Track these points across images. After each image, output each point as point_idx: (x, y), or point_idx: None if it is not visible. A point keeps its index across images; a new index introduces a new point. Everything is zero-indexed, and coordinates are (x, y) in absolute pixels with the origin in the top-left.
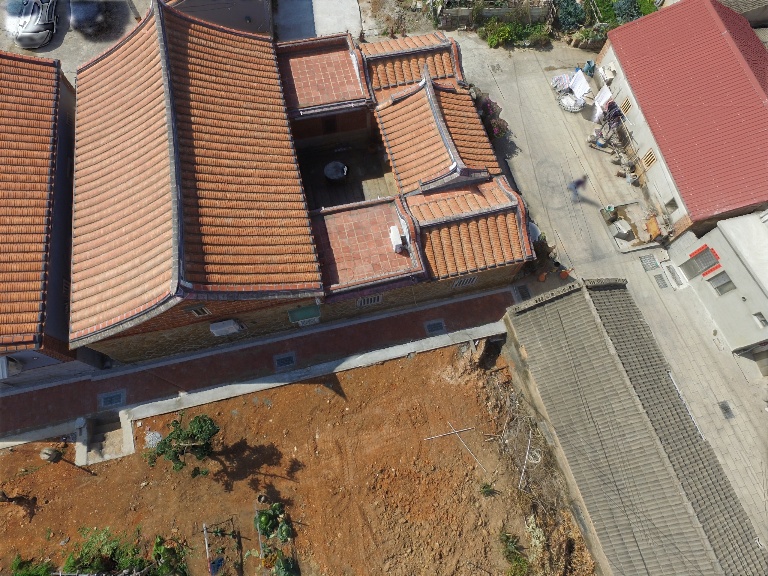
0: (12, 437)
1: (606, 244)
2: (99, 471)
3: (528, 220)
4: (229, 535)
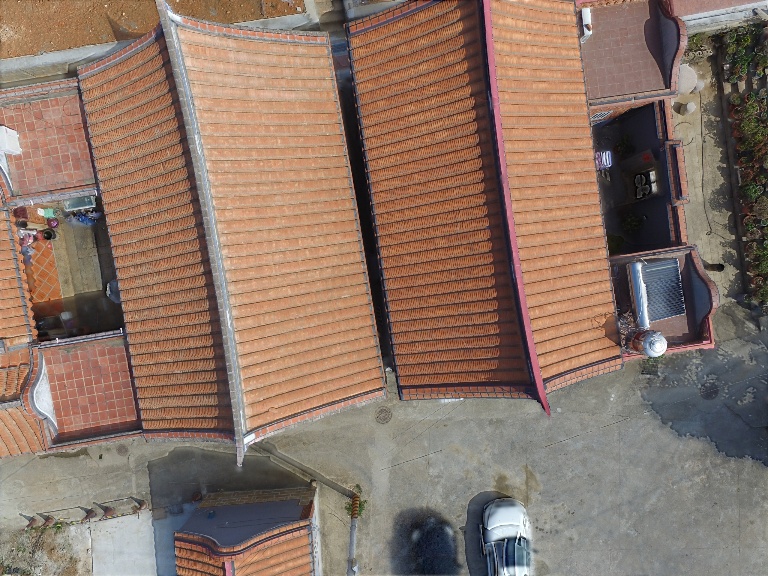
0: None
1: None
2: None
3: None
4: None
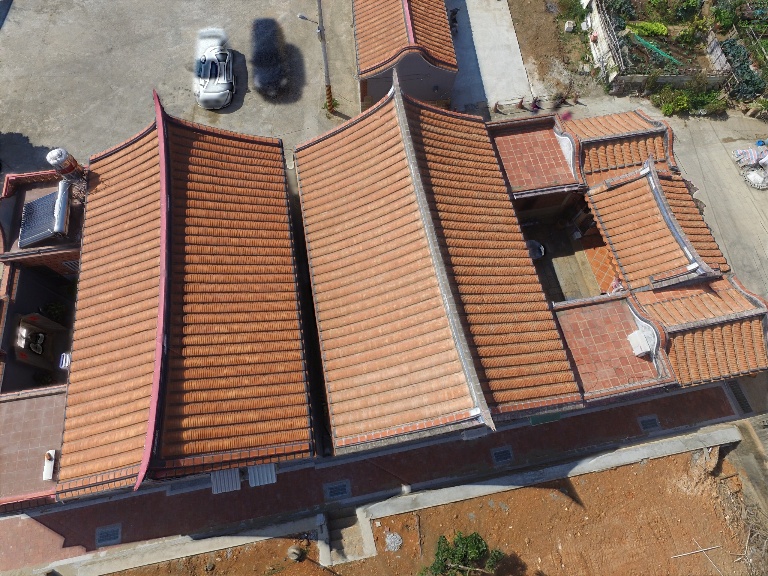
0: (255, 531)
1: None
2: (344, 573)
3: None
4: None
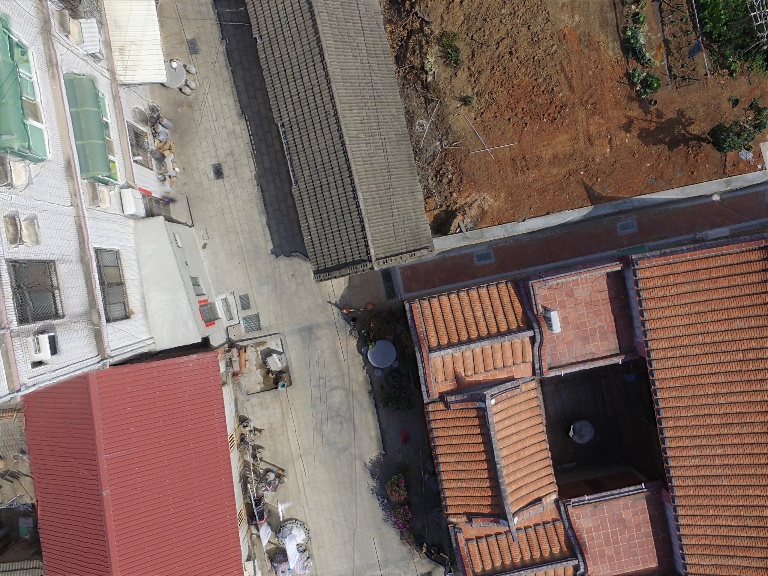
0: None
1: (294, 344)
2: None
3: (413, 341)
4: (679, 76)
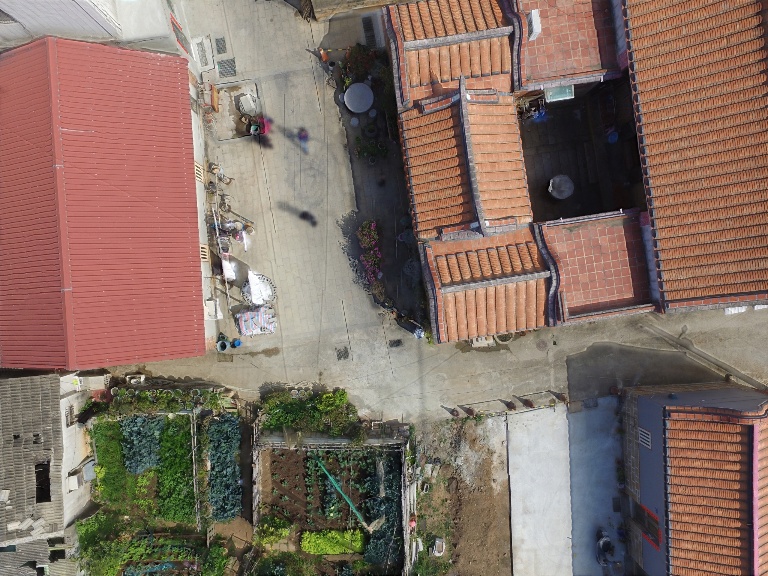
0: None
1: (269, 91)
2: None
3: None
4: None
